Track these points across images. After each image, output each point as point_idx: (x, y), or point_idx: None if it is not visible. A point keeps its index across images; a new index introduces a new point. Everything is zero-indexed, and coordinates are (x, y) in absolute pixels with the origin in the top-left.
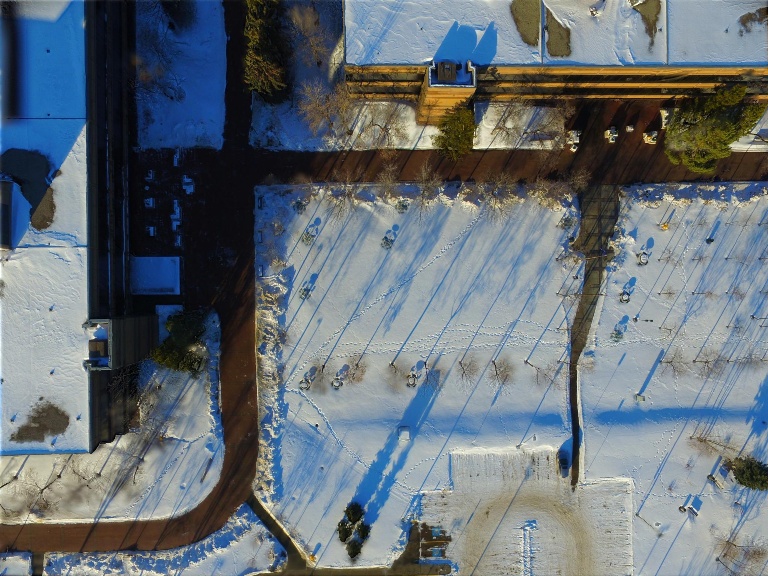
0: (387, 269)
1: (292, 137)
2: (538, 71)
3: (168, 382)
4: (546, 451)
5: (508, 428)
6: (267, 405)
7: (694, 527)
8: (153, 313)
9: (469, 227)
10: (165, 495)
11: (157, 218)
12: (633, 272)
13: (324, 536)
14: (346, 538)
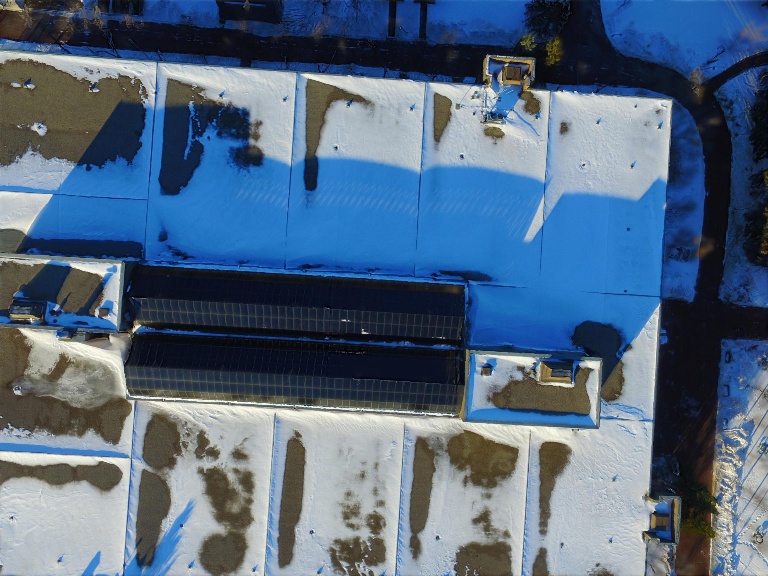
0: None
1: (763, 295)
2: None
3: None
4: None
5: None
6: (719, 555)
7: None
8: None
9: None
10: None
11: None
12: None
13: None
14: None
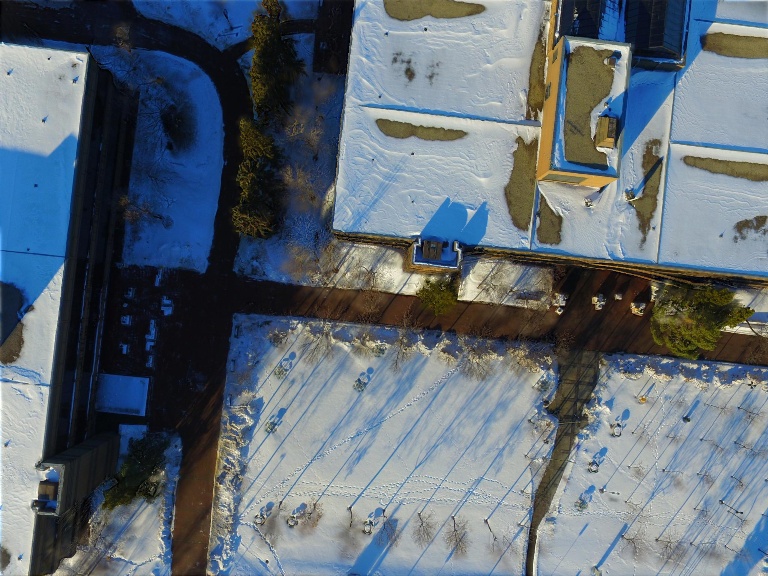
0: (357, 412)
1: (277, 269)
2: (526, 253)
3: None
4: None
5: None
6: (219, 536)
7: None
8: (116, 432)
9: (444, 378)
10: None
11: (132, 335)
12: (605, 442)
13: None
14: None
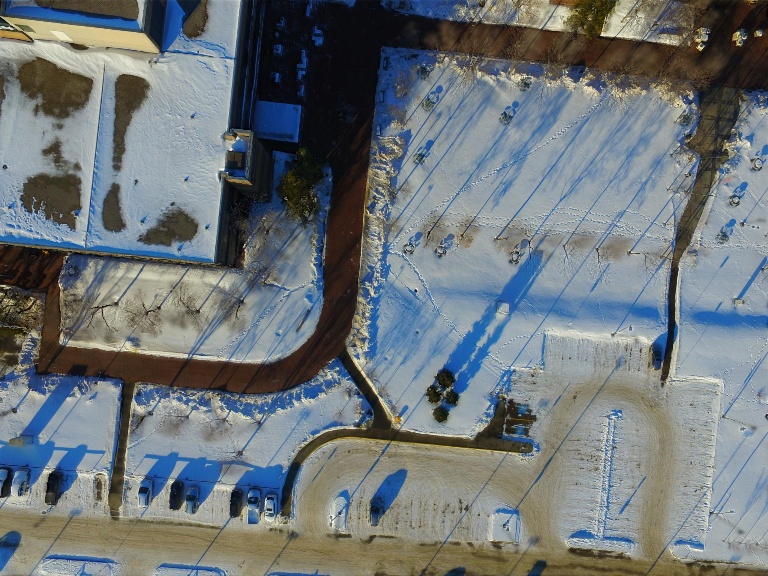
0: (503, 144)
1: (424, 2)
2: None
3: (276, 228)
4: (640, 343)
5: (605, 315)
6: (369, 264)
7: None
8: None
9: (588, 113)
10: (260, 340)
11: (283, 66)
12: (745, 177)
13: (412, 399)
14: None
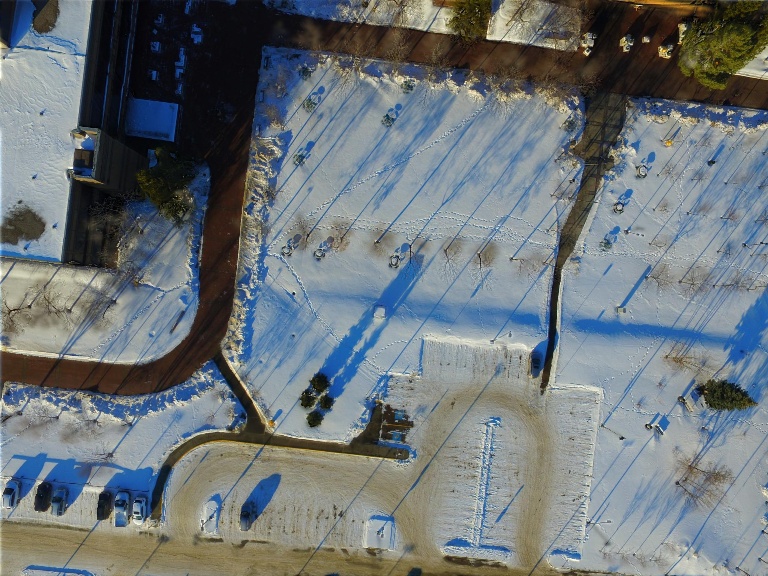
0: (384, 147)
1: (307, 1)
2: None
3: (151, 228)
4: (520, 350)
5: (485, 321)
6: (247, 266)
7: (658, 446)
8: (145, 156)
9: (472, 116)
10: (133, 340)
11: (161, 64)
12: (630, 184)
13: (286, 403)
14: (308, 406)
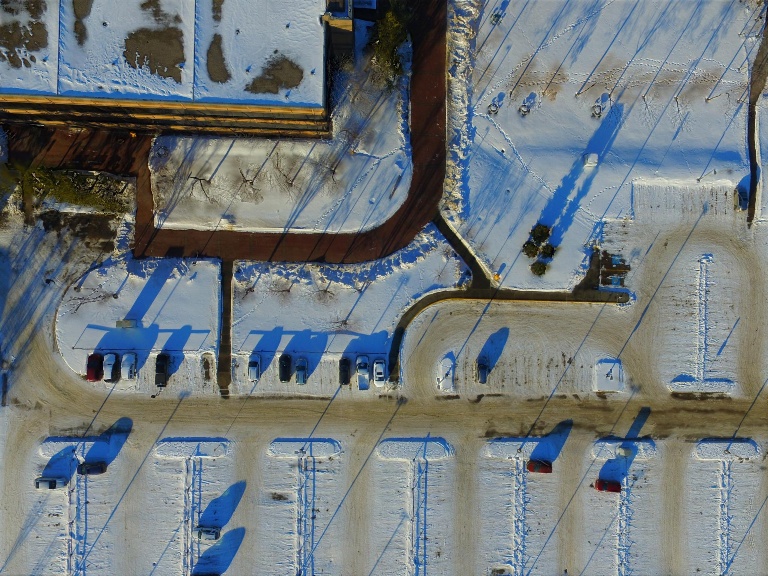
0: (576, 0)
1: None
2: None
3: (361, 97)
4: (724, 187)
5: (689, 161)
6: (455, 128)
7: None
8: None
9: None
10: (354, 209)
11: None
12: None
13: (509, 256)
14: None
